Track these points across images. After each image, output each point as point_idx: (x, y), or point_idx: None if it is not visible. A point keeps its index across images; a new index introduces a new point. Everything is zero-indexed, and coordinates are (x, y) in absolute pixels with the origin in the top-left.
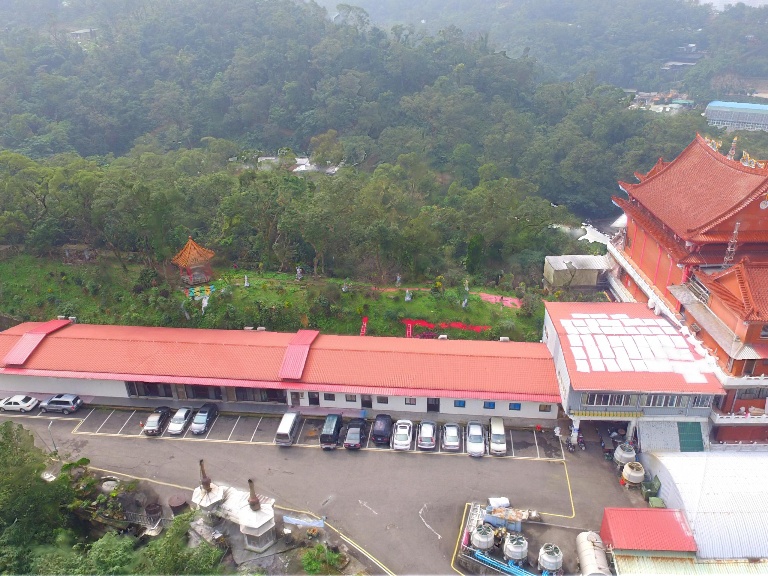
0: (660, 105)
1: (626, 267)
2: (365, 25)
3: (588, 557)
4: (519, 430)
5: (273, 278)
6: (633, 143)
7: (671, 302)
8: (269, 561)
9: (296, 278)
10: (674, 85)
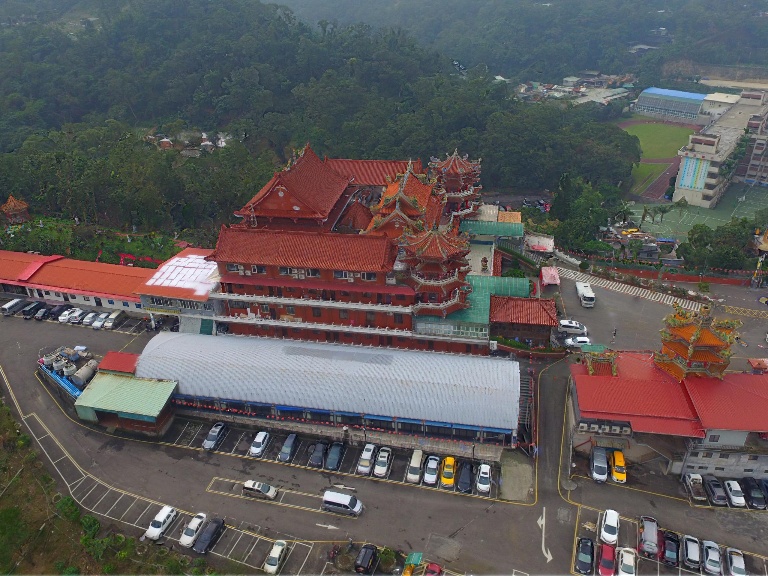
0: (607, 89)
1: None
2: (293, 20)
3: None
4: (135, 319)
5: (63, 223)
6: (466, 133)
7: None
8: None
9: (75, 224)
10: (635, 68)
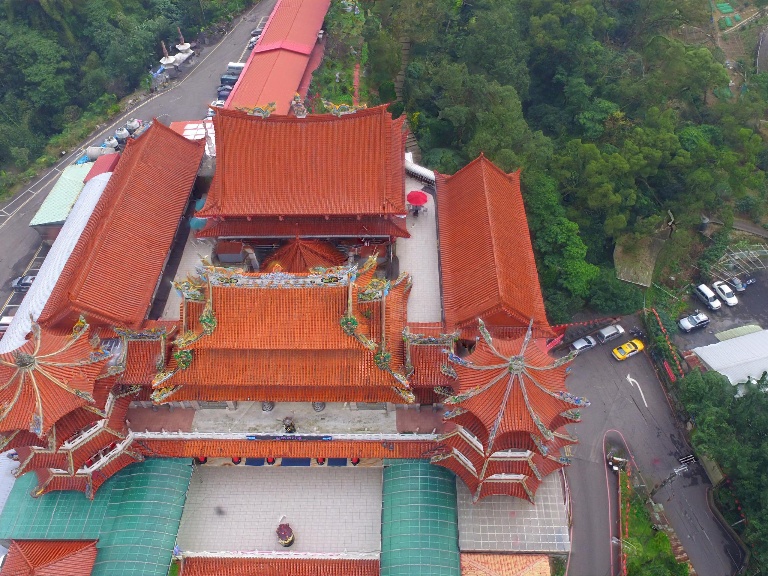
0: None
1: None
2: None
3: None
4: None
5: None
6: None
7: None
8: (161, 79)
9: None
10: None
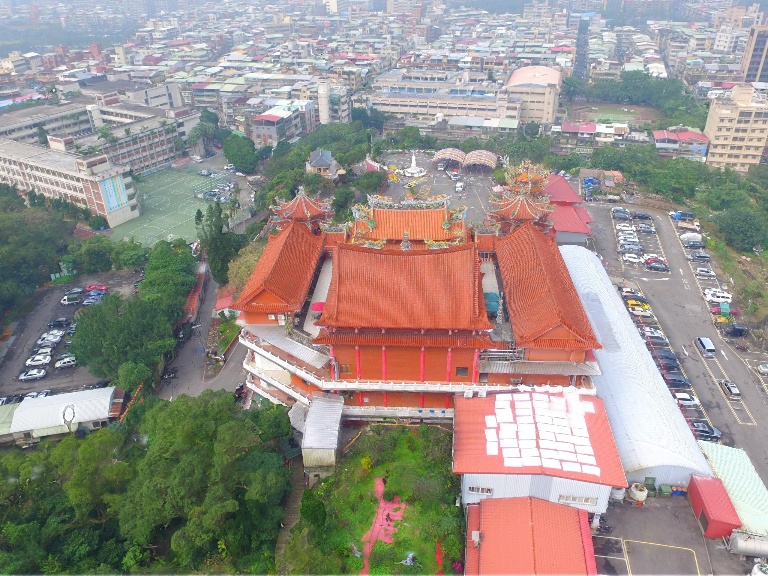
0: None
1: (383, 388)
2: None
3: (763, 546)
4: None
5: None
6: None
7: (463, 381)
8: None
9: None
10: None
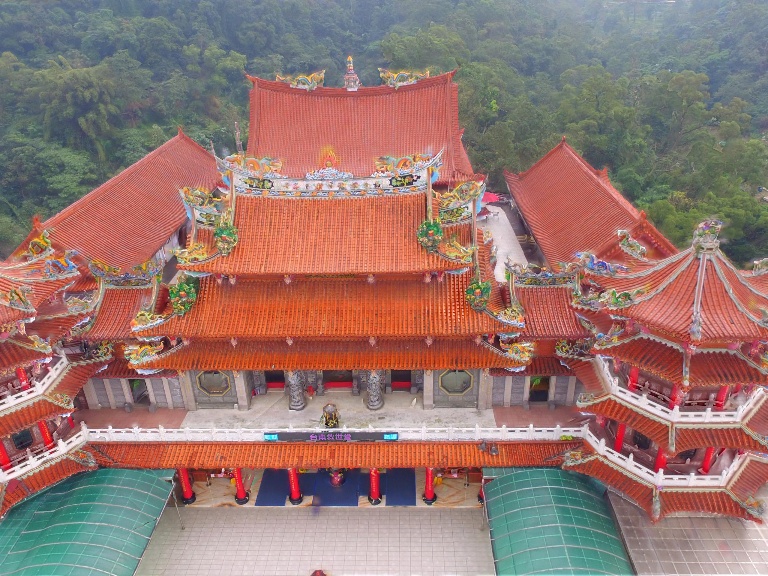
0: None
1: None
2: None
3: None
4: None
5: None
6: None
7: None
8: None
9: None
10: None
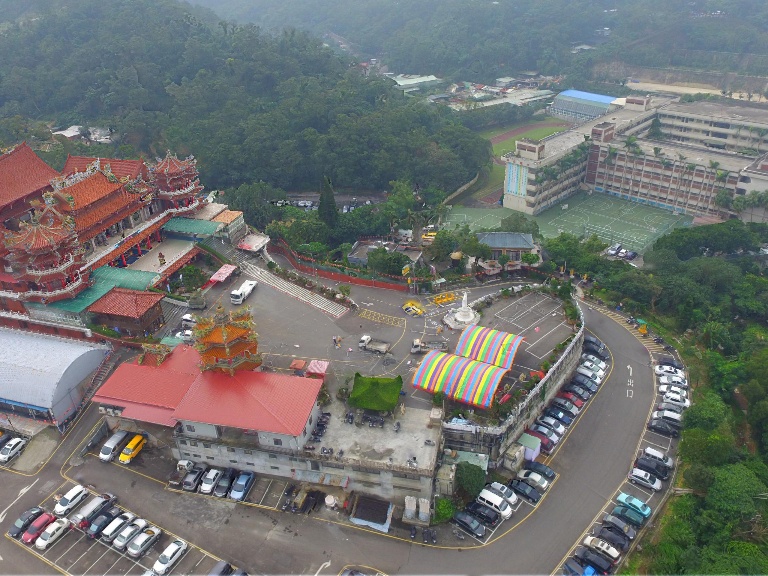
0: None
1: None
2: (194, 21)
3: None
4: None
5: None
6: (308, 133)
7: None
8: None
9: None
10: None
